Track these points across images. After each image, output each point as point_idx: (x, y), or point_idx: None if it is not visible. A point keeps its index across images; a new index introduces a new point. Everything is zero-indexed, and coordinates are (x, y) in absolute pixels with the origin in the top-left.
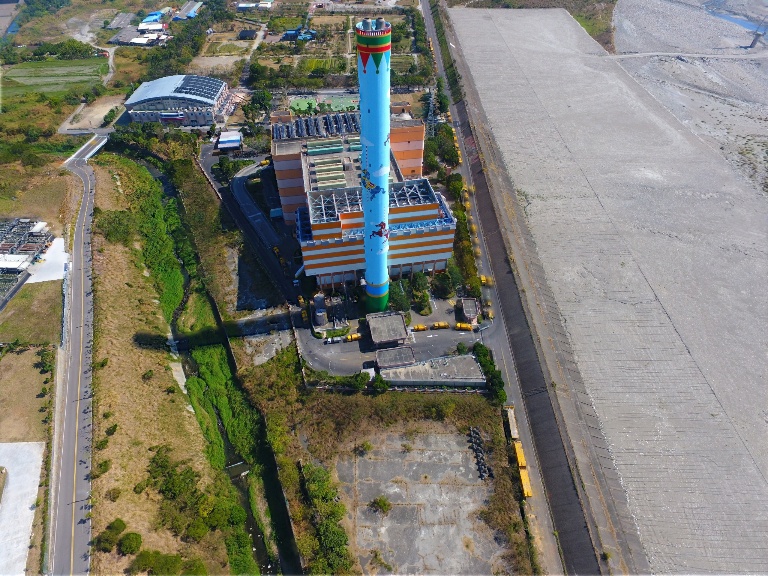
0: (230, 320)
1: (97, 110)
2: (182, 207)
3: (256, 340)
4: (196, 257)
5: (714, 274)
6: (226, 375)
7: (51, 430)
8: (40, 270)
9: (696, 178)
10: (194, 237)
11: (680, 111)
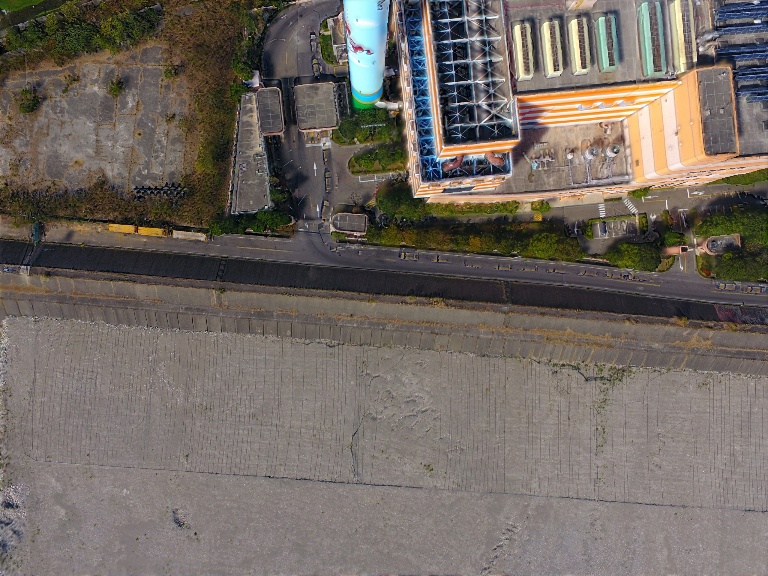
0: None
1: None
2: None
3: None
4: None
5: None
6: None
7: None
8: None
9: None
10: None
11: None
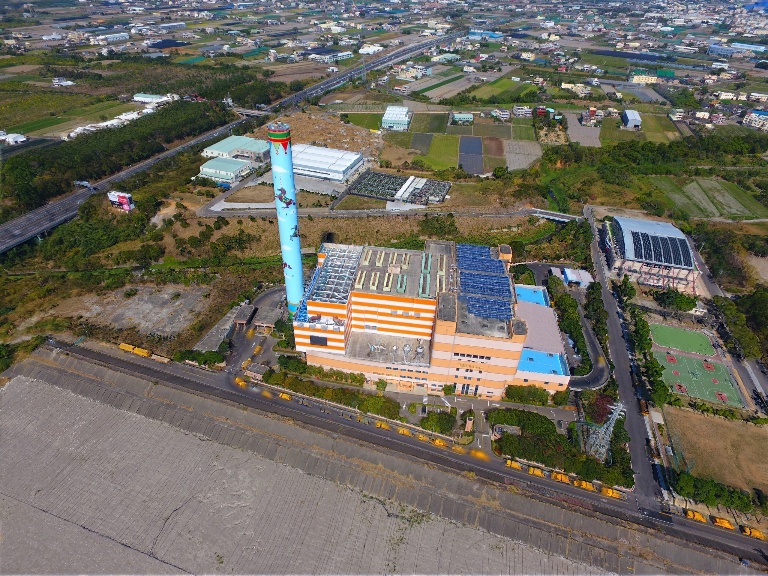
0: None
1: (638, 218)
2: None
3: (308, 272)
4: None
5: None
6: None
7: None
8: (397, 204)
9: None
10: None
11: None
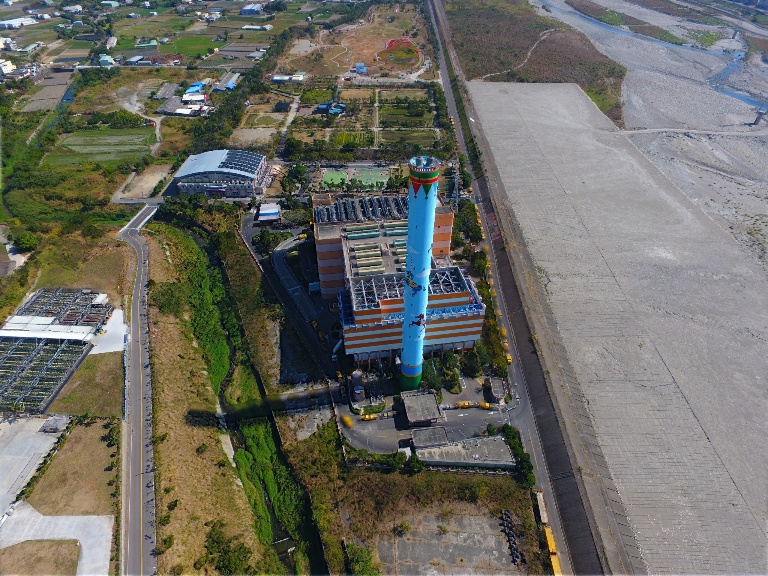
0: (274, 394)
1: (146, 179)
2: (226, 278)
3: (298, 415)
4: (240, 329)
5: (729, 358)
6: (271, 449)
7: (119, 504)
8: (102, 341)
9: (707, 258)
10: (238, 309)
11: (689, 189)
